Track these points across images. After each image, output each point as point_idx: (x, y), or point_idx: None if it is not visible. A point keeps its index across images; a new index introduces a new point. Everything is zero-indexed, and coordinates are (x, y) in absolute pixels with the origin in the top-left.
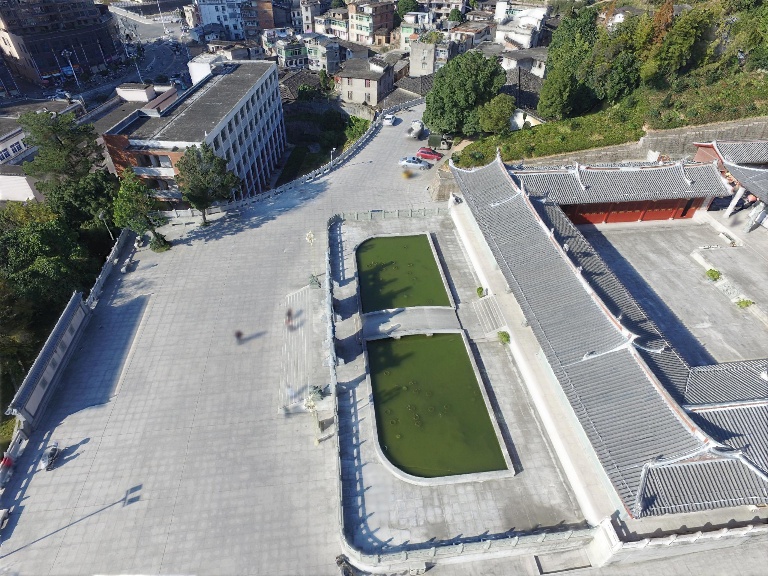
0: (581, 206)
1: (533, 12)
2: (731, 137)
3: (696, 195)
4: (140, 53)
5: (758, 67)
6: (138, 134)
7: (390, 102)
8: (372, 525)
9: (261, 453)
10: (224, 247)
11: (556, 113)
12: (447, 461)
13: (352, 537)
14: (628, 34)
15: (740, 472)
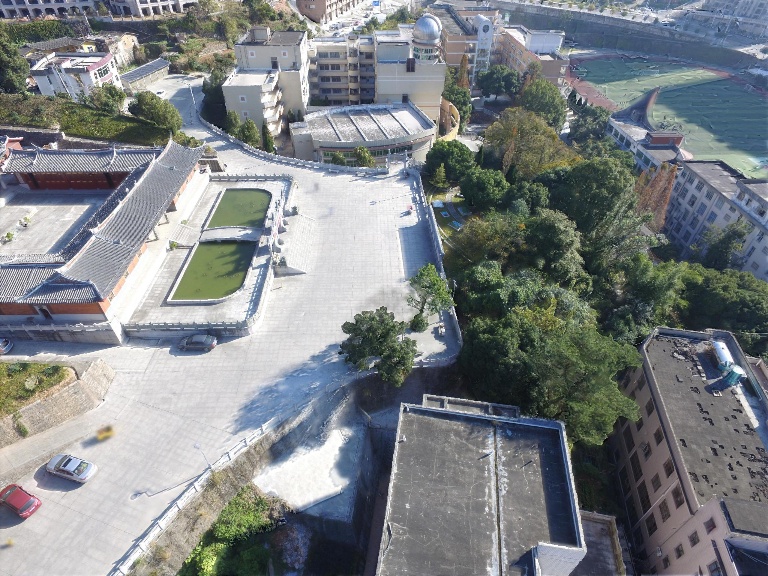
0: None
1: None
2: None
3: None
4: None
5: None
6: (527, 460)
7: None
8: None
9: None
10: None
11: None
12: None
13: None
14: None
15: None
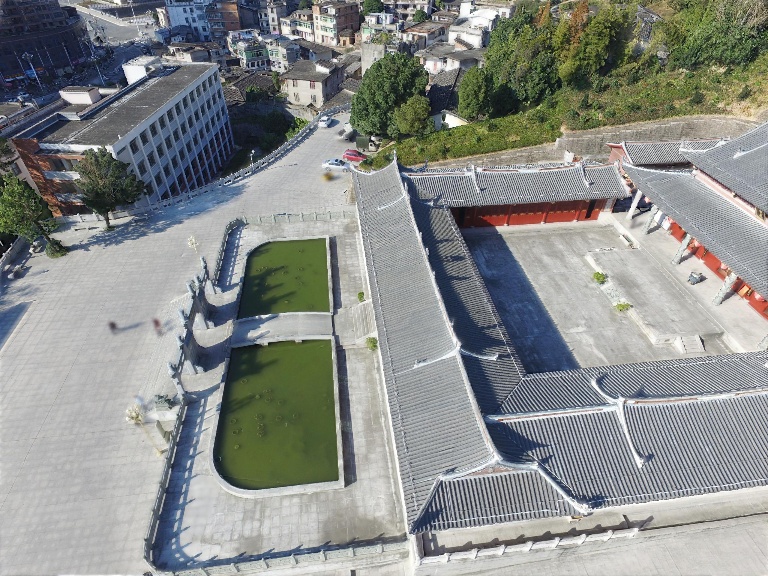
0: (479, 208)
1: (485, 12)
2: (649, 137)
3: (593, 197)
4: (109, 55)
5: (680, 67)
6: (52, 138)
7: (334, 104)
8: (184, 540)
9: (99, 465)
10: (122, 252)
11: (473, 114)
12: (279, 472)
13: (159, 553)
14: (548, 34)
15: (537, 484)
